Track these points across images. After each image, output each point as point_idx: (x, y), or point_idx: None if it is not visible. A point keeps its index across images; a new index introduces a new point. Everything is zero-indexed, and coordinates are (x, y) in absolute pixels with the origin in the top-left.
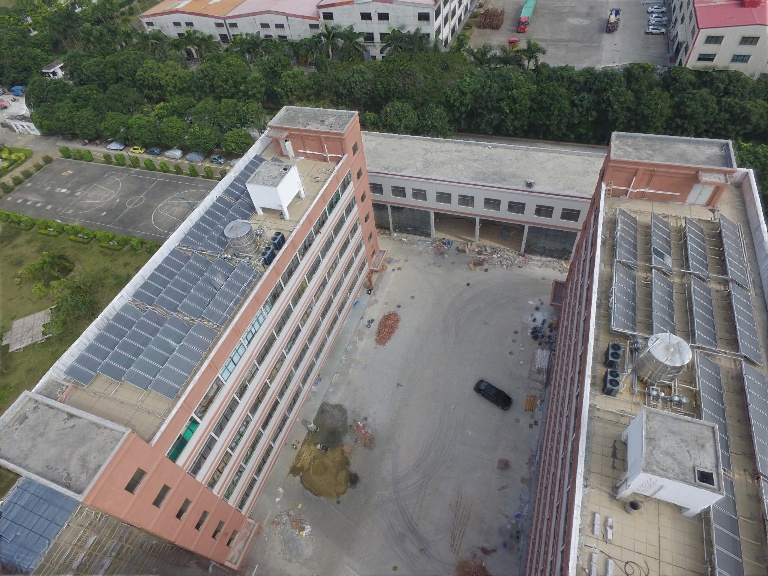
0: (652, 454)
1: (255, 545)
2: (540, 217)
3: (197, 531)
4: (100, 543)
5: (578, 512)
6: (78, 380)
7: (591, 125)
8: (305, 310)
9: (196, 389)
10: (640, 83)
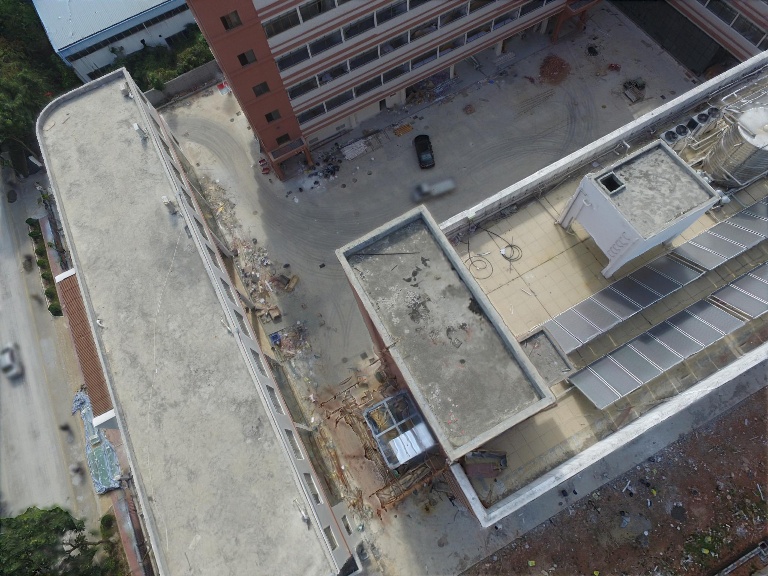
0: None
1: None
2: (195, 209)
3: None
4: None
5: None
6: None
7: None
8: None
9: None
10: None
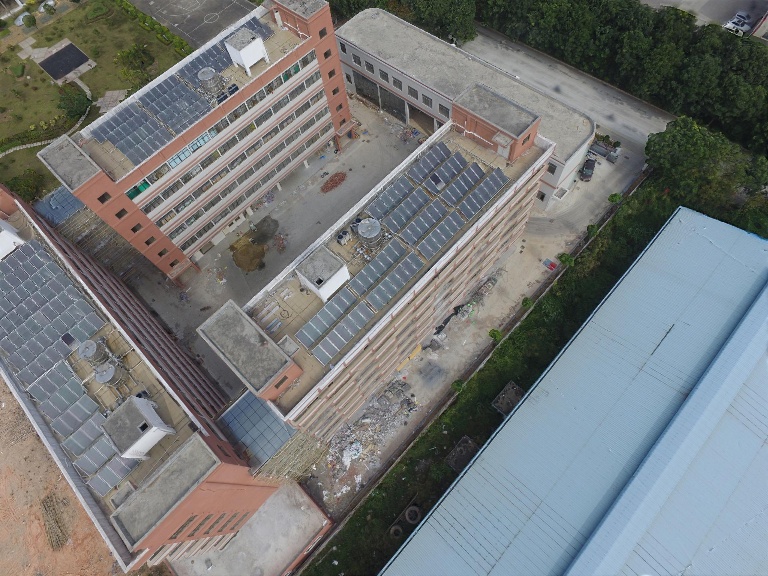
0: (307, 265)
1: (194, 277)
2: None
3: (147, 245)
4: (97, 230)
5: (273, 281)
6: (97, 139)
7: (607, 62)
8: (252, 145)
9: (148, 165)
10: (665, 32)
